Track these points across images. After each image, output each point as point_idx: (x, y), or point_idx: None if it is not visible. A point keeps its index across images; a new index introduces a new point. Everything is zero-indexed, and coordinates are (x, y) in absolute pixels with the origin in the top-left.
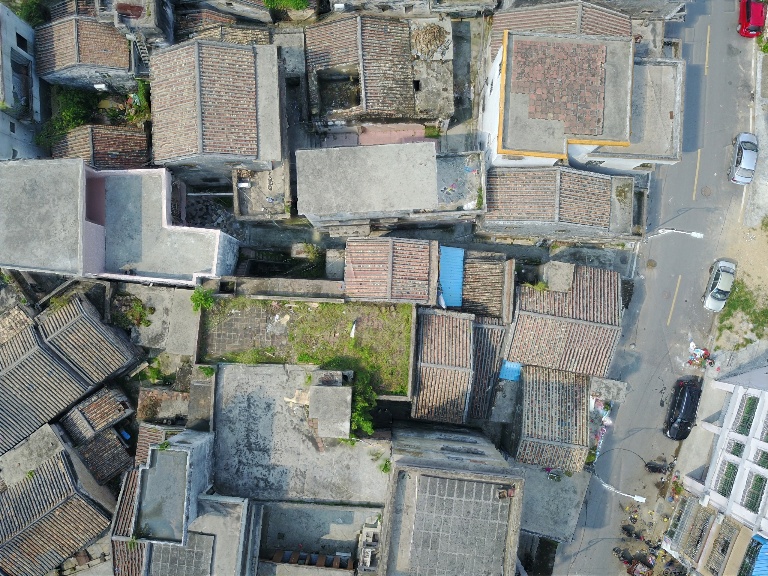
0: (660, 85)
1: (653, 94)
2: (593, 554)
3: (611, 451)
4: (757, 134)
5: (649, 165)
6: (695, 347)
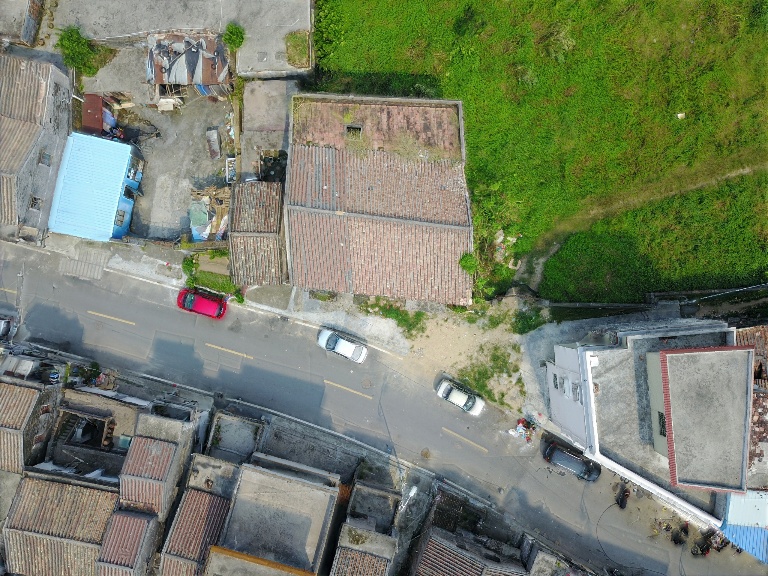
0: (259, 486)
1: (267, 495)
2: (693, 574)
3: (598, 534)
4: (321, 323)
5: (333, 484)
6: (514, 430)
